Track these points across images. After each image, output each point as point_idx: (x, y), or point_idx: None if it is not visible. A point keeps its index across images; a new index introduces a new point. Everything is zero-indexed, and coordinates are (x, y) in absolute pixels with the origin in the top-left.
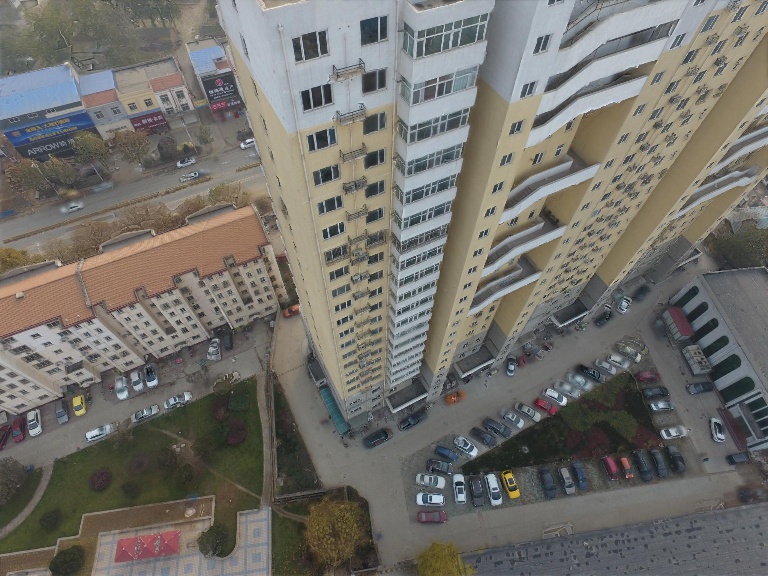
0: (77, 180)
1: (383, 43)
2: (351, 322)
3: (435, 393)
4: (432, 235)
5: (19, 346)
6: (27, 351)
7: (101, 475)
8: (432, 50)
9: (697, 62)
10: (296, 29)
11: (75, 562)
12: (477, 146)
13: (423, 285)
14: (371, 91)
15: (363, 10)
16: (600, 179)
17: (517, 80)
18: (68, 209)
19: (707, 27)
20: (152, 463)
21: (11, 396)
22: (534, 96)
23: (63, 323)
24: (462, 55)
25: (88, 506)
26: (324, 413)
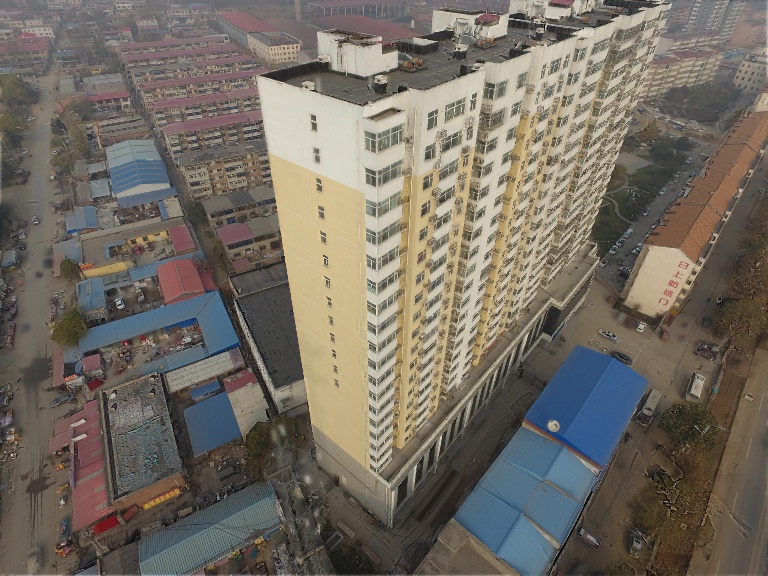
0: None
1: None
2: None
3: None
4: None
5: None
6: None
7: (607, 223)
8: None
9: None
10: None
11: None
12: None
13: None
14: None
15: None
16: None
17: None
18: None
19: None
20: (594, 232)
21: None
22: None
23: None
24: None
25: None
26: None
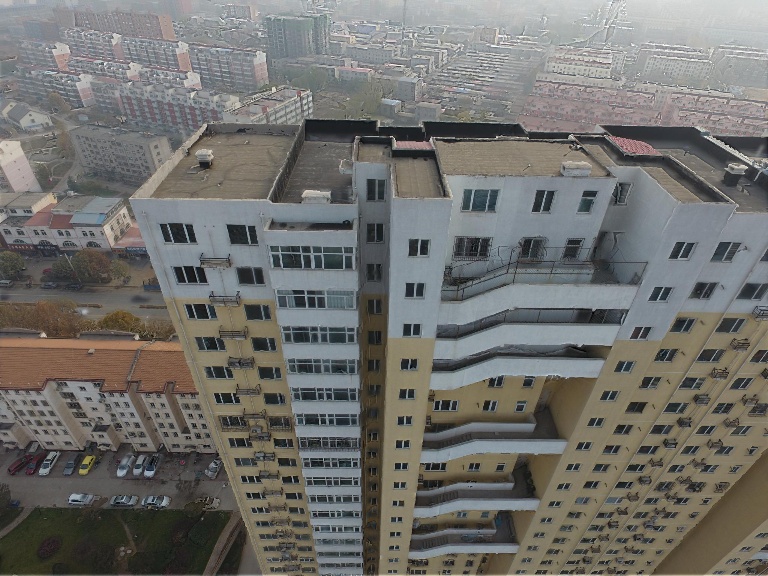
0: None
1: (253, 247)
2: (264, 501)
3: None
4: (341, 443)
5: (68, 392)
6: (72, 398)
7: (52, 542)
8: (294, 265)
9: (726, 364)
10: (162, 218)
11: None
12: None
13: (342, 495)
14: (250, 284)
15: (227, 217)
16: (575, 460)
17: (391, 317)
18: None
19: (727, 328)
20: None
21: (46, 431)
22: (423, 338)
23: (102, 387)
24: (329, 277)
25: (23, 568)
26: None
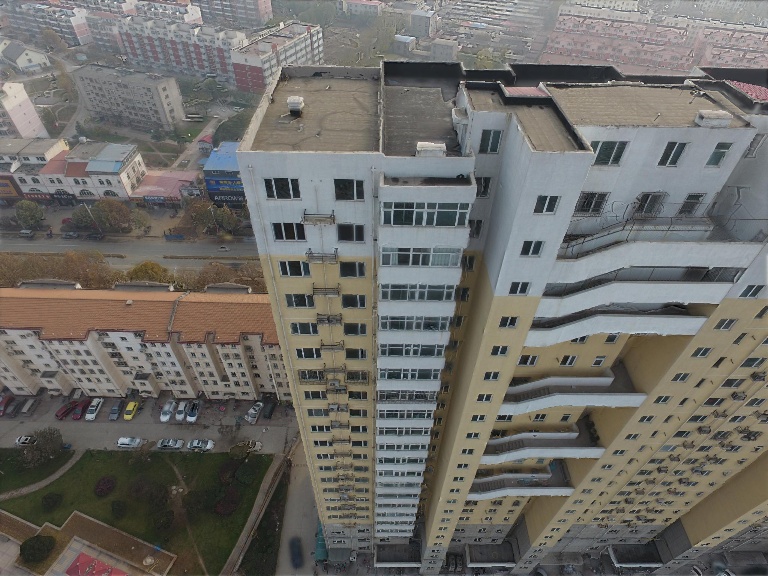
0: (237, 228)
1: (359, 203)
2: (330, 448)
3: (432, 568)
4: (419, 396)
5: (109, 342)
6: (113, 348)
7: (107, 482)
8: (404, 222)
9: None
10: (268, 172)
11: (40, 552)
12: (475, 325)
13: (410, 443)
14: (348, 240)
15: (336, 171)
16: (650, 412)
17: (501, 275)
18: (219, 248)
19: None
20: (149, 493)
21: (89, 379)
22: (529, 297)
23: (144, 337)
24: (439, 234)
25: (83, 505)
26: (313, 527)
